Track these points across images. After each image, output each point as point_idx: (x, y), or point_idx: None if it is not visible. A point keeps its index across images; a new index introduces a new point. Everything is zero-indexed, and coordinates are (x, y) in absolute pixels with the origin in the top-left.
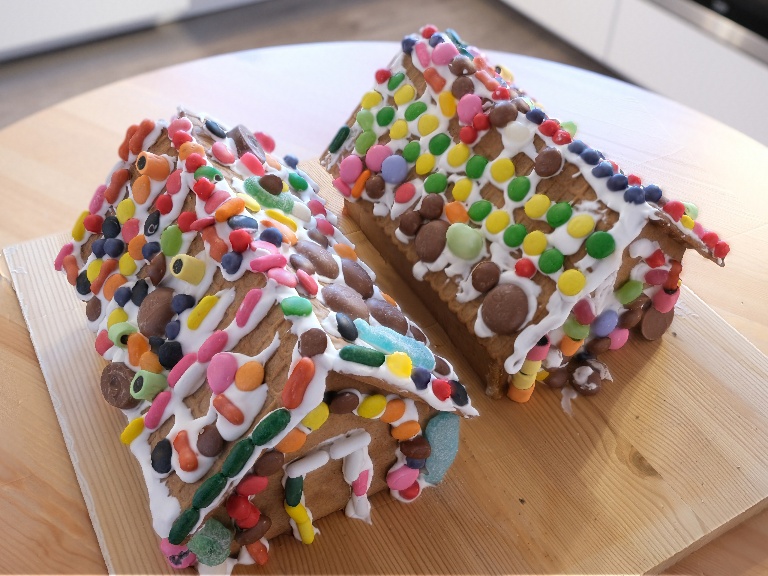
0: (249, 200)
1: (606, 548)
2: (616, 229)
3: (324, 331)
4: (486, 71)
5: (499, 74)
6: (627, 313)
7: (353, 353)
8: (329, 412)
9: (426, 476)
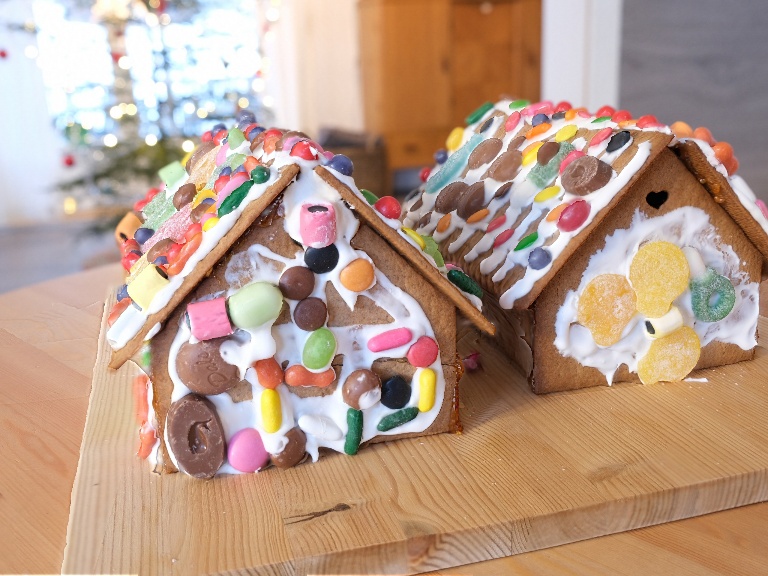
0: None
1: None
2: None
3: None
4: None
5: None
6: None
7: None
8: None
9: None
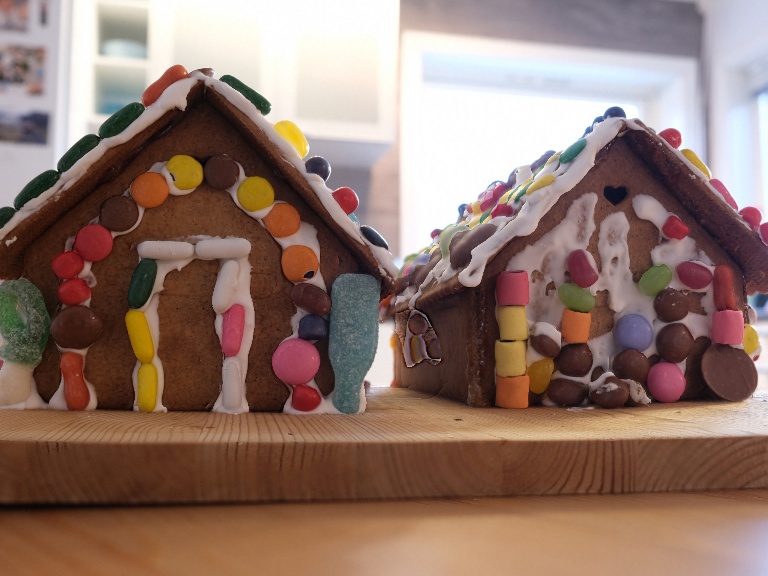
0: None
1: (564, 431)
2: None
3: None
4: None
5: None
6: (666, 328)
7: (231, 77)
8: (204, 180)
9: (334, 391)
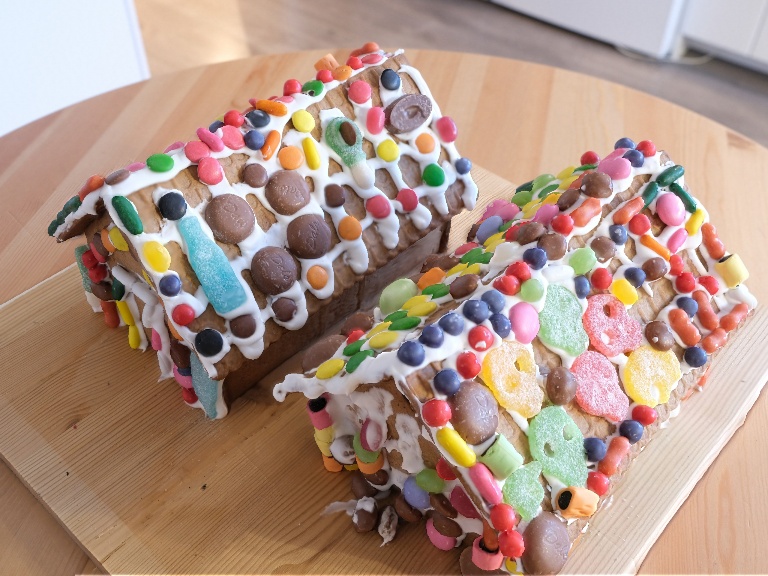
0: (300, 118)
1: (164, 568)
2: (371, 359)
3: (143, 185)
4: (620, 211)
5: (721, 262)
6: None
7: (116, 201)
8: None
9: None
